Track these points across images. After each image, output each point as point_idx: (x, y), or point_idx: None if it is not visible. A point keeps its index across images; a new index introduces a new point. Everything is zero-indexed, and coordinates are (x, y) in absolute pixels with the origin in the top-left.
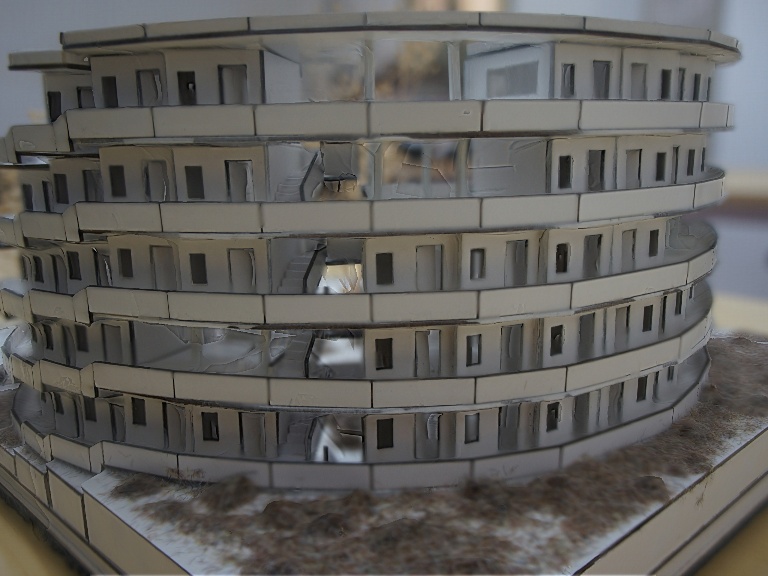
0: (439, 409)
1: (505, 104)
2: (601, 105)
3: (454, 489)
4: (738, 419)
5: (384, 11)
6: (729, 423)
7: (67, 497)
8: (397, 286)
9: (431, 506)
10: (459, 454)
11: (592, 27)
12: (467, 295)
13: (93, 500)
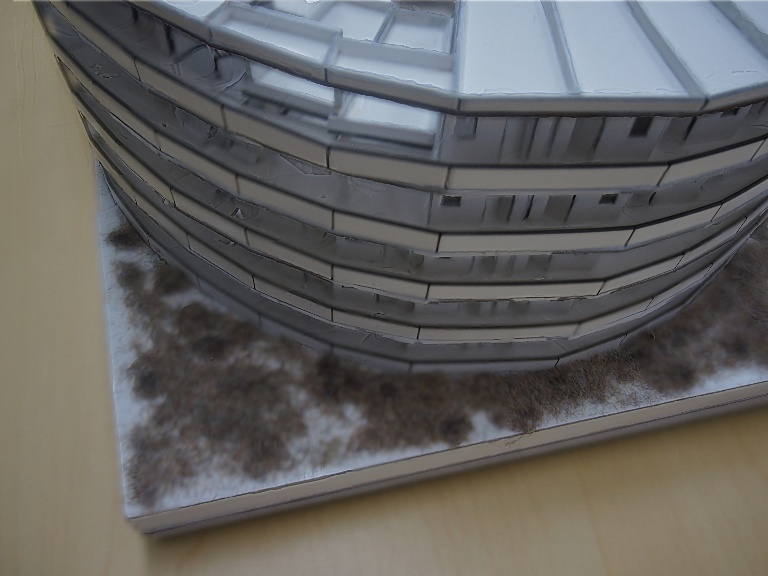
0: (304, 312)
1: (350, 156)
2: (479, 172)
3: (317, 353)
4: (632, 384)
5: (222, 37)
6: (616, 385)
7: None
8: (283, 218)
9: (289, 361)
10: (336, 328)
11: (472, 107)
12: (321, 265)
13: None
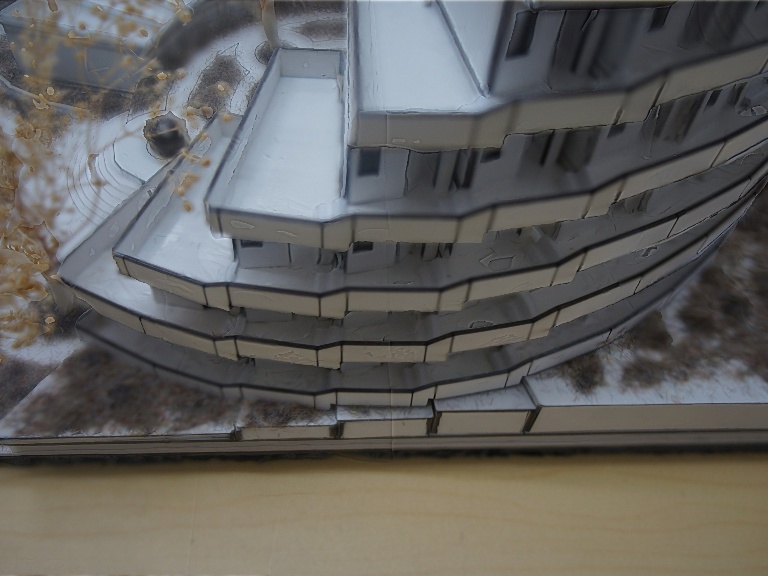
0: None
1: None
2: None
3: None
4: None
5: None
6: None
7: (492, 419)
8: None
9: (743, 251)
10: None
11: None
12: None
13: (567, 407)
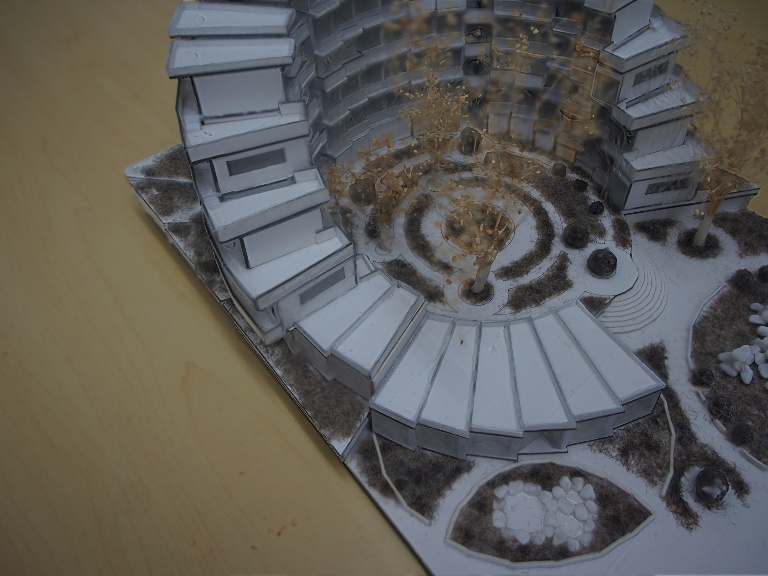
0: None
1: None
2: None
3: None
4: None
5: None
6: None
7: None
8: None
9: None
10: None
11: None
12: None
13: None
